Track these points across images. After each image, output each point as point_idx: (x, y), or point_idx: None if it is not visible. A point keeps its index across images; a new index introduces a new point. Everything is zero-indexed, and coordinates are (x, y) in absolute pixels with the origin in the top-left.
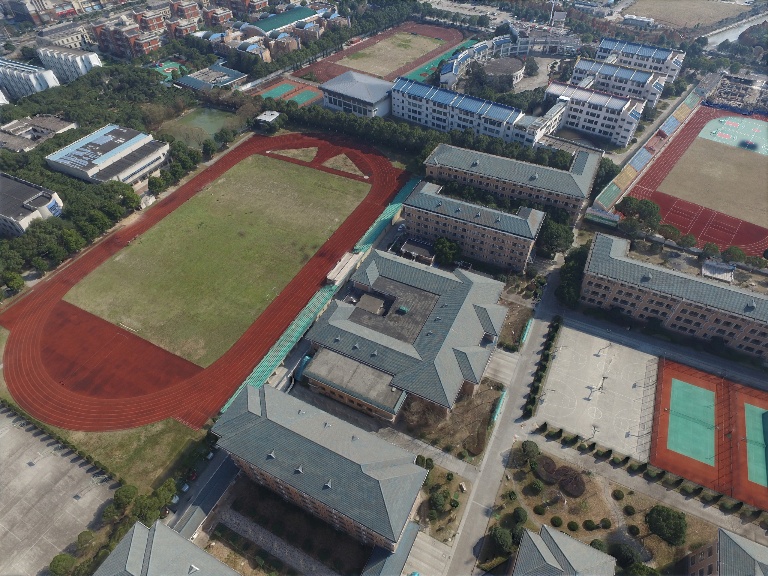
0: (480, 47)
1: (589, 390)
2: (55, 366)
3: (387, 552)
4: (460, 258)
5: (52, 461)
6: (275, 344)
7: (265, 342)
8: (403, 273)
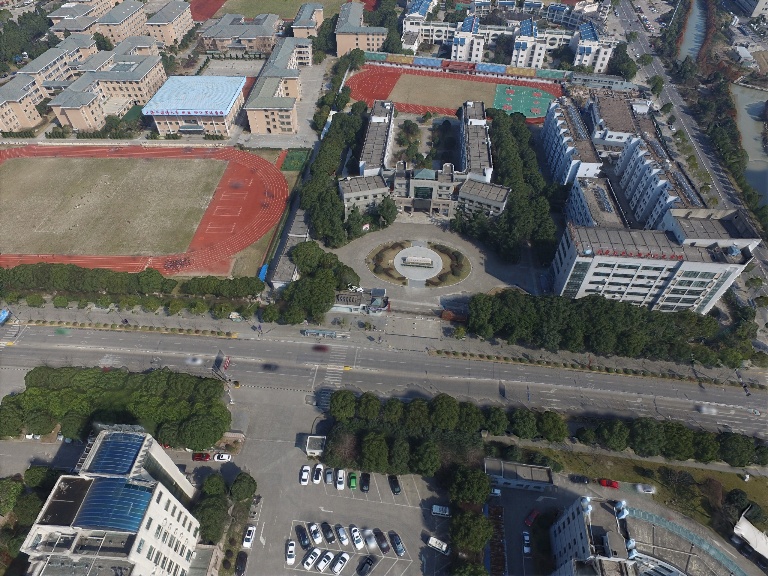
0: (534, 4)
1: None
2: (203, 2)
3: None
4: (291, 35)
5: None
6: None
7: None
8: None
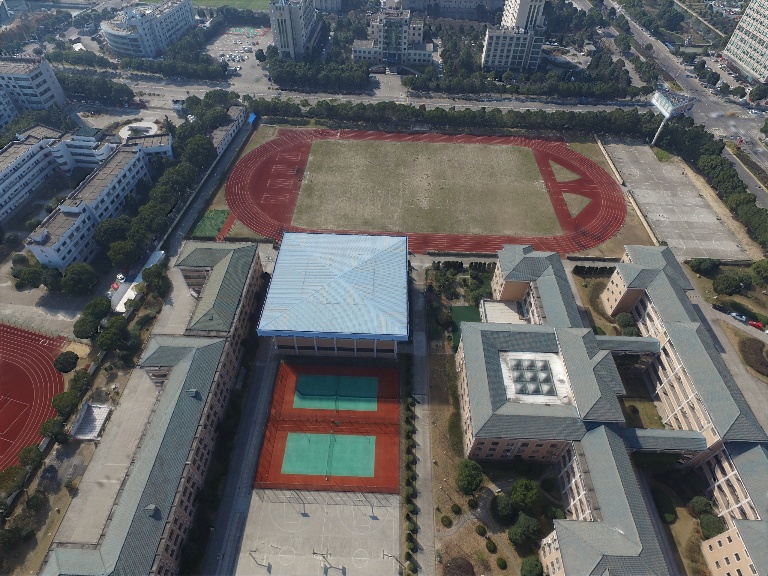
0: None
1: (330, 571)
2: None
3: None
4: None
5: None
6: None
7: None
8: None
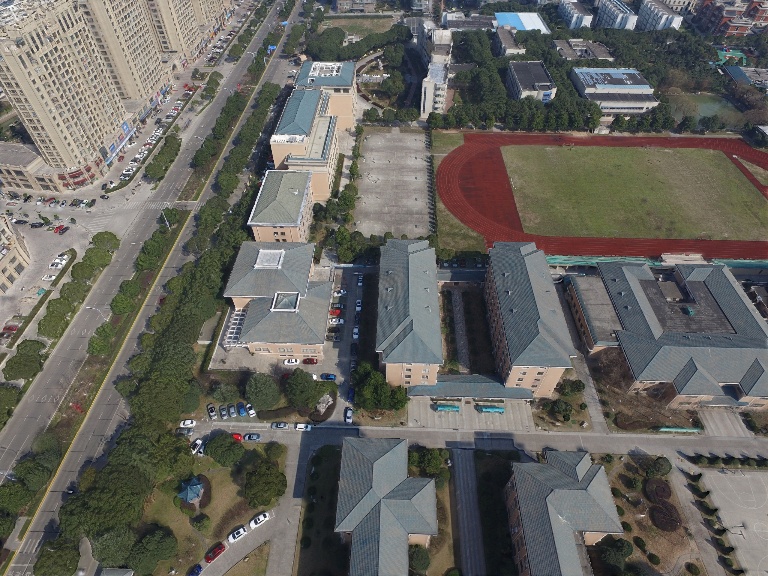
0: None
1: None
2: (465, 172)
3: (502, 382)
4: None
5: (423, 205)
6: (576, 256)
7: (572, 251)
8: (726, 295)
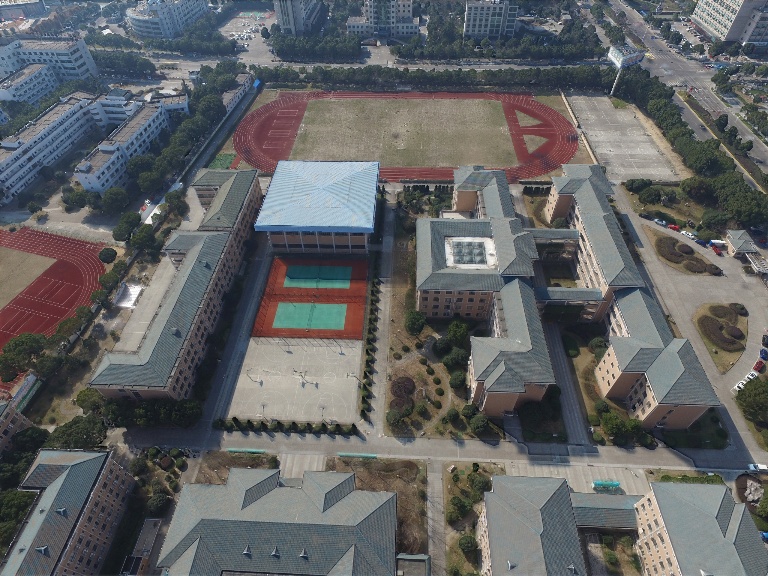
0: None
1: (306, 385)
2: None
3: None
4: None
5: None
6: None
7: None
8: None
